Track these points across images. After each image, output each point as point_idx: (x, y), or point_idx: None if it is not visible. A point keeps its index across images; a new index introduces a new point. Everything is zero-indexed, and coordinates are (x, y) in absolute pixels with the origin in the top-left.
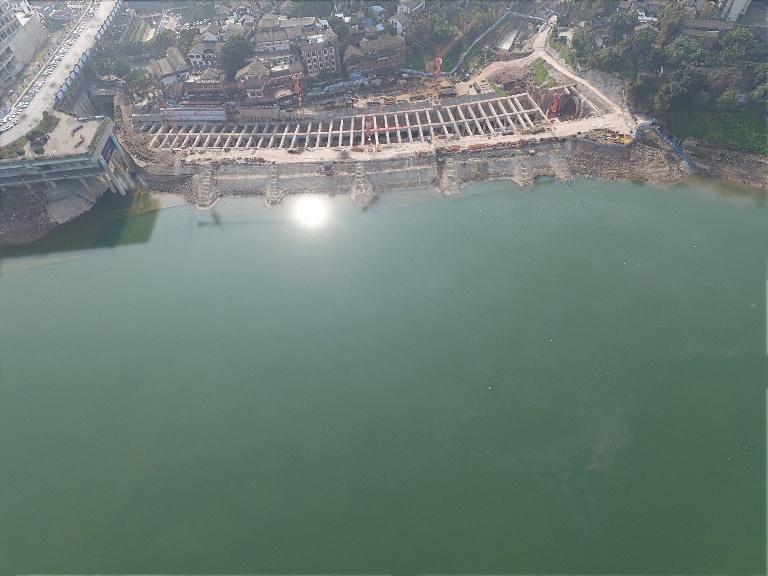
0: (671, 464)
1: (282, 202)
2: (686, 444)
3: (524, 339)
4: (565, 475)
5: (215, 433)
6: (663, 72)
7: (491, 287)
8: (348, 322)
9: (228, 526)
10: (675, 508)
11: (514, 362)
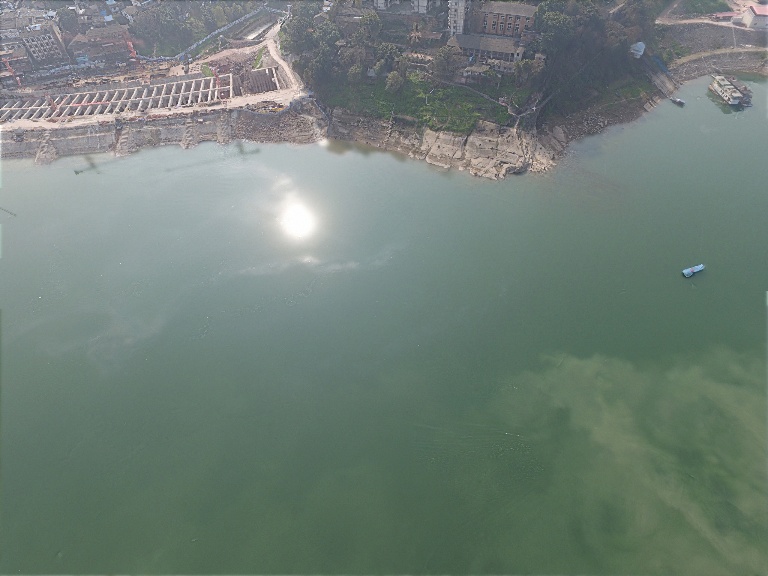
0: (142, 345)
1: None
2: (172, 333)
3: (98, 262)
4: (47, 353)
5: None
6: None
7: (103, 226)
8: None
9: None
10: (118, 373)
11: None
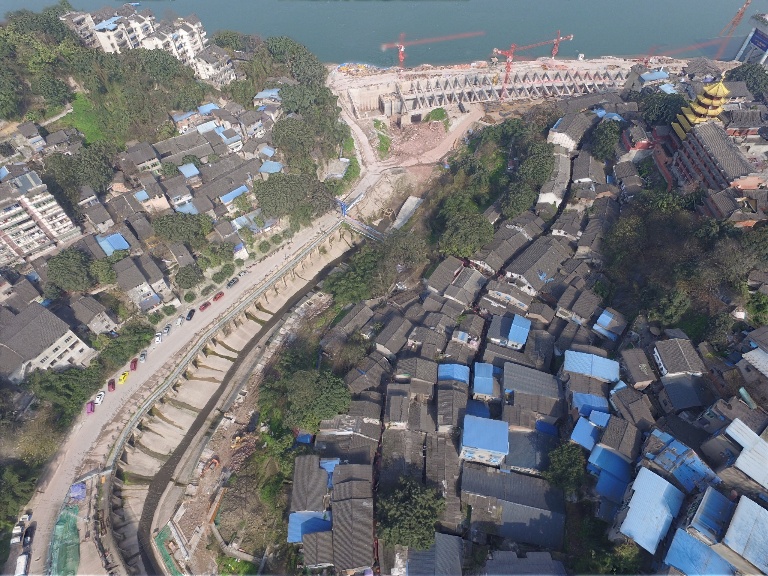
0: None
1: (602, 58)
2: None
3: (443, 12)
4: None
5: None
6: None
7: None
8: (528, 17)
9: None
10: None
11: (449, 8)
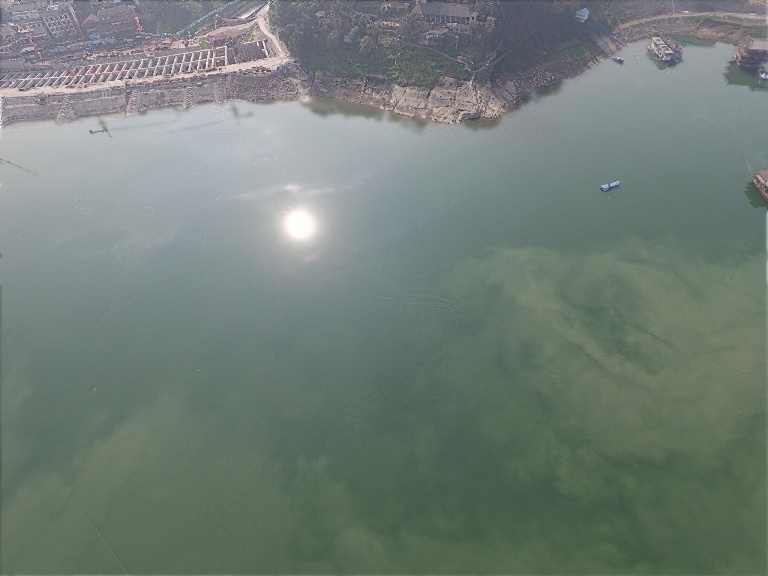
0: None
1: (4, 125)
2: (178, 243)
3: (115, 194)
4: (77, 256)
5: None
6: None
7: (118, 168)
8: (3, 191)
9: None
10: (135, 269)
11: None
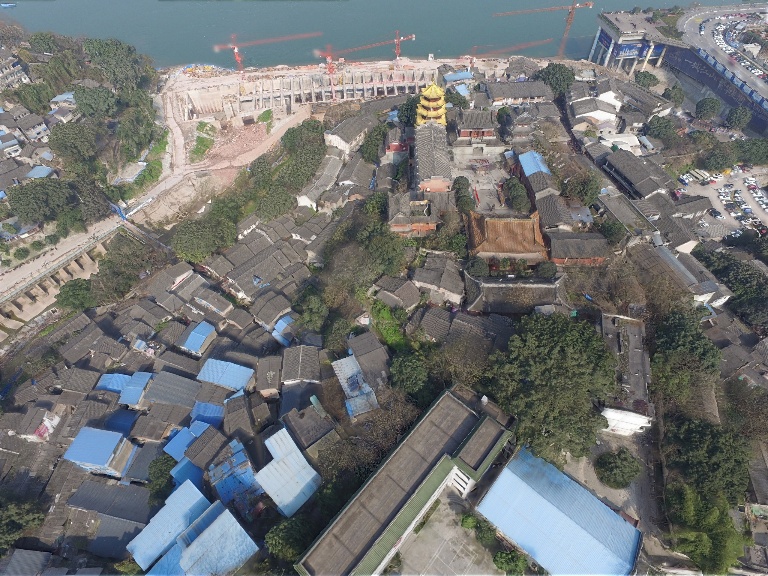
0: None
1: None
2: None
3: (320, 12)
4: None
5: None
6: None
7: None
8: (403, 17)
9: None
10: None
11: (327, 7)
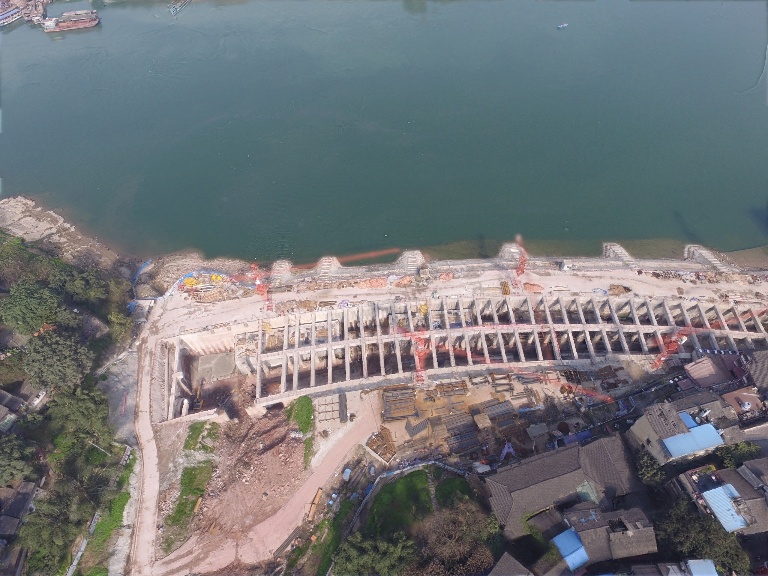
0: (329, 102)
1: (604, 249)
2: None
3: (381, 144)
4: (382, 94)
5: (564, 113)
6: (76, 310)
7: (393, 174)
8: (501, 155)
9: (538, 90)
10: None
11: (391, 135)
